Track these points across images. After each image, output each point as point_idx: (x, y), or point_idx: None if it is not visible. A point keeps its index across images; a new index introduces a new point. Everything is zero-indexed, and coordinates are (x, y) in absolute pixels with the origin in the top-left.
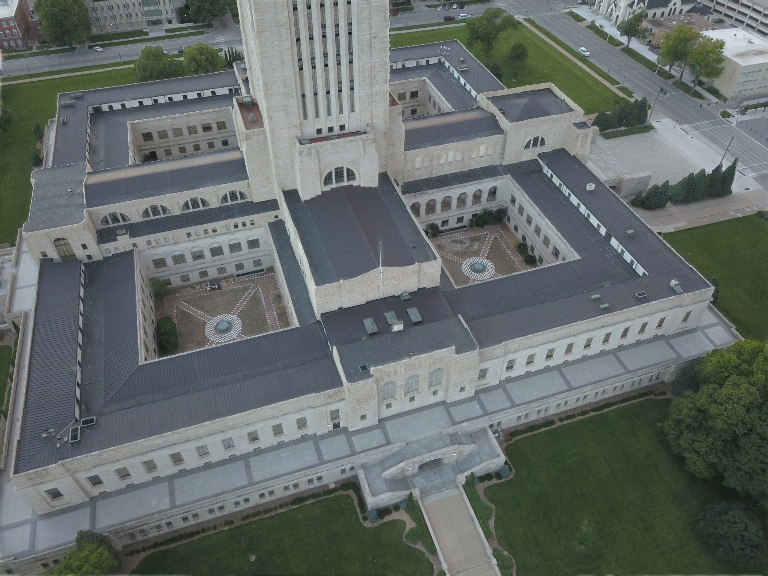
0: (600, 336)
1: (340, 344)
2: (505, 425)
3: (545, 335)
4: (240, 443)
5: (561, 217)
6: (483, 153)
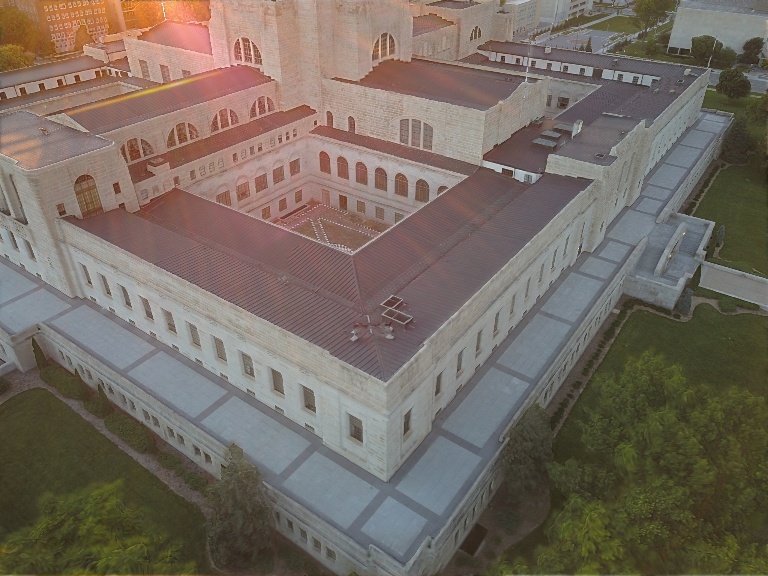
0: None
1: (535, 165)
2: None
3: (666, 114)
4: (534, 286)
5: None
6: (444, 47)
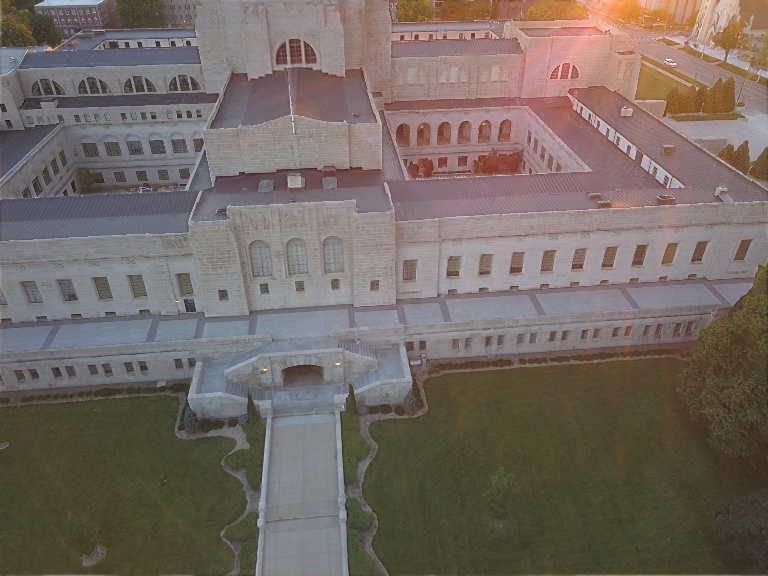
0: (597, 250)
1: None
2: (433, 352)
3: (503, 221)
4: (48, 296)
5: (580, 141)
6: (496, 78)
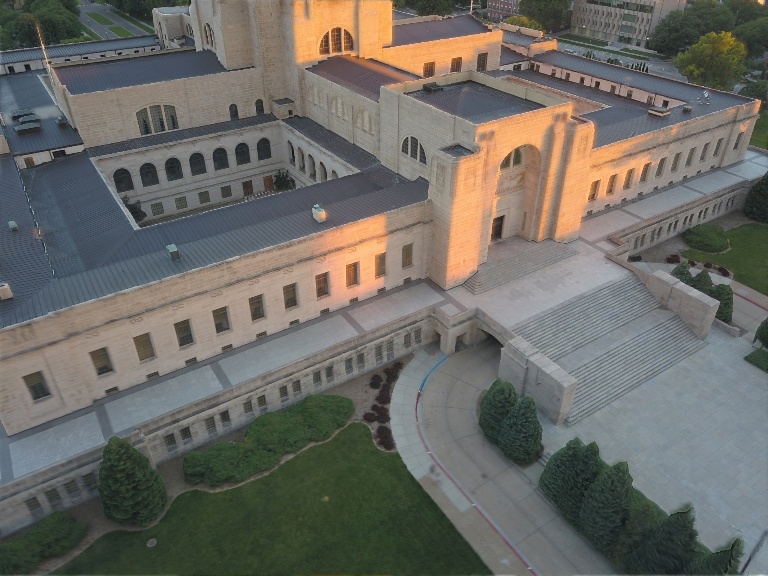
0: None
1: None
2: None
3: None
4: None
5: (257, 217)
6: (368, 127)
